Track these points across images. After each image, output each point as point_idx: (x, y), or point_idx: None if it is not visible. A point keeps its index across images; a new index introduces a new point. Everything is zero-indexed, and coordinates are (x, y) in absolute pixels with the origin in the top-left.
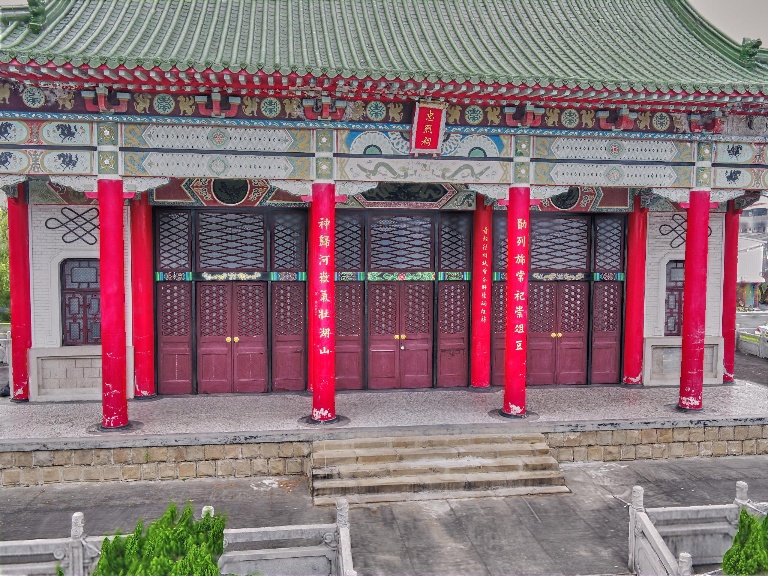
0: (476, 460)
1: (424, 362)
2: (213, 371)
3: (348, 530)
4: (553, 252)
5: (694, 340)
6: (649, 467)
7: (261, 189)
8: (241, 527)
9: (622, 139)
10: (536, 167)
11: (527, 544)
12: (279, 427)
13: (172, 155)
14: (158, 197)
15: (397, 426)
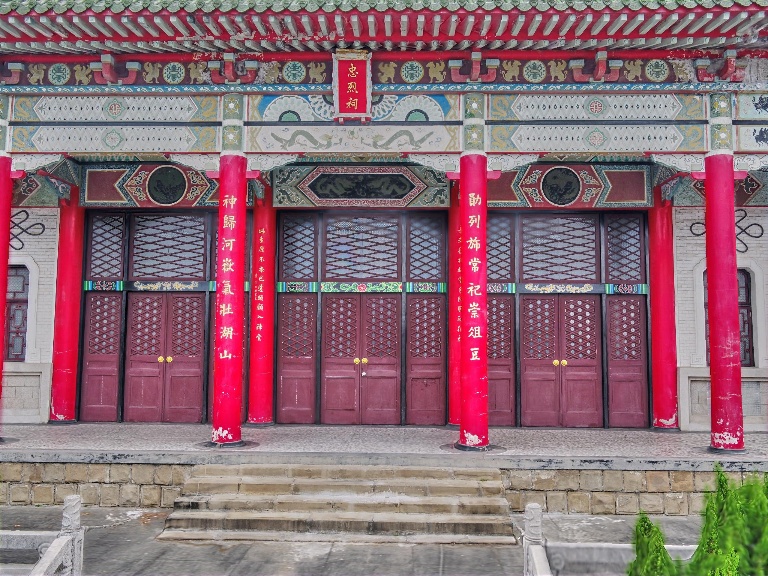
0: (397, 497)
1: (390, 393)
2: (142, 396)
3: (67, 539)
4: (551, 259)
5: (724, 352)
6: (654, 523)
7: (200, 187)
8: None
9: (605, 94)
10: (492, 131)
11: None
12: (164, 448)
13: (64, 128)
14: (90, 198)
15: (308, 452)
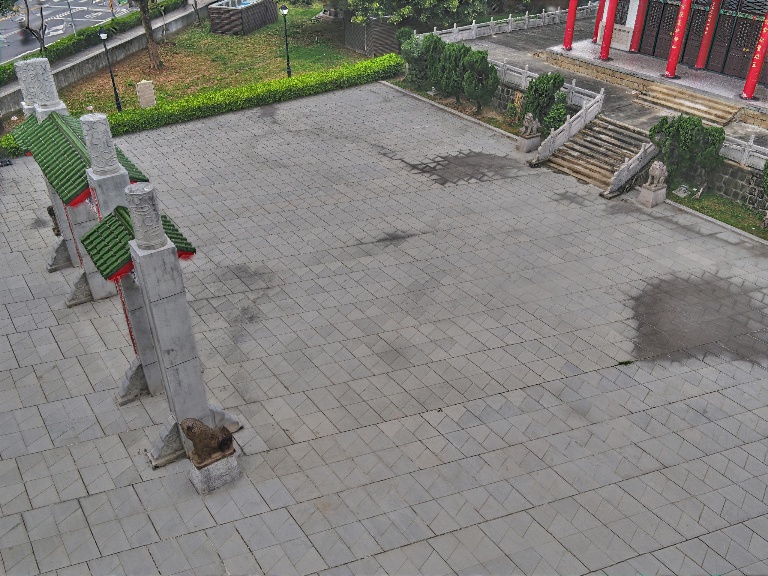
0: (702, 107)
1: None
2: (662, 47)
3: (600, 96)
4: None
5: None
6: None
7: None
8: None
9: None
10: None
11: None
12: (649, 74)
13: None
14: None
15: (688, 86)
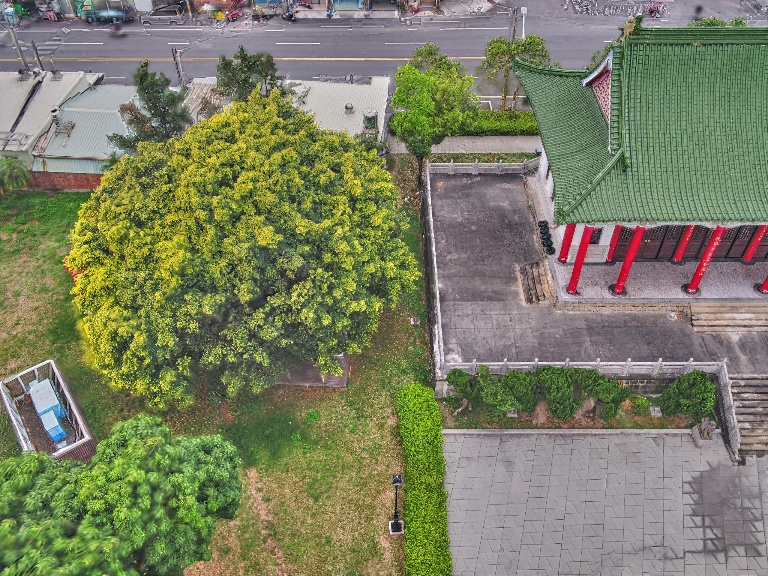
0: (748, 315)
1: (725, 249)
2: None
3: None
4: None
5: None
6: None
7: None
8: (697, 362)
9: None
10: None
11: (766, 359)
12: (677, 295)
13: None
14: None
15: (720, 298)
